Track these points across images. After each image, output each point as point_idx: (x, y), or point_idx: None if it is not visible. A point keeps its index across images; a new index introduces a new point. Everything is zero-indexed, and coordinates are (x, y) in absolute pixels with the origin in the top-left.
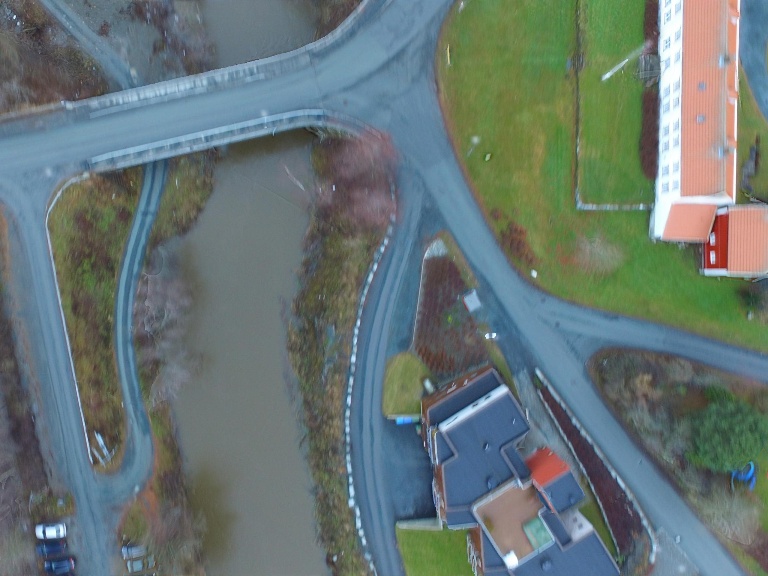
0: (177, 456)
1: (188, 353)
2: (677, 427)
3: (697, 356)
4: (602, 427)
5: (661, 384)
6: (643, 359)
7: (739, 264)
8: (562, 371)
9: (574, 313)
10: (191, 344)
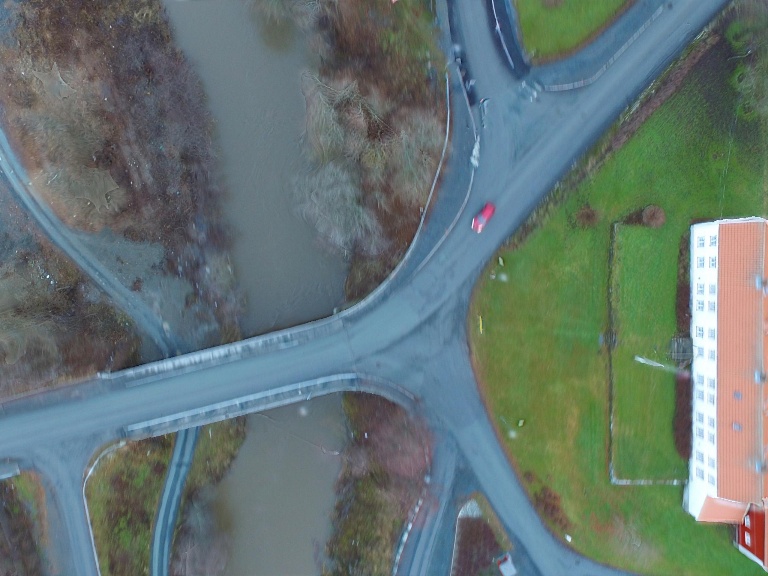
0: None
1: None
2: None
3: None
4: None
5: None
6: None
7: None
8: None
9: None
10: None
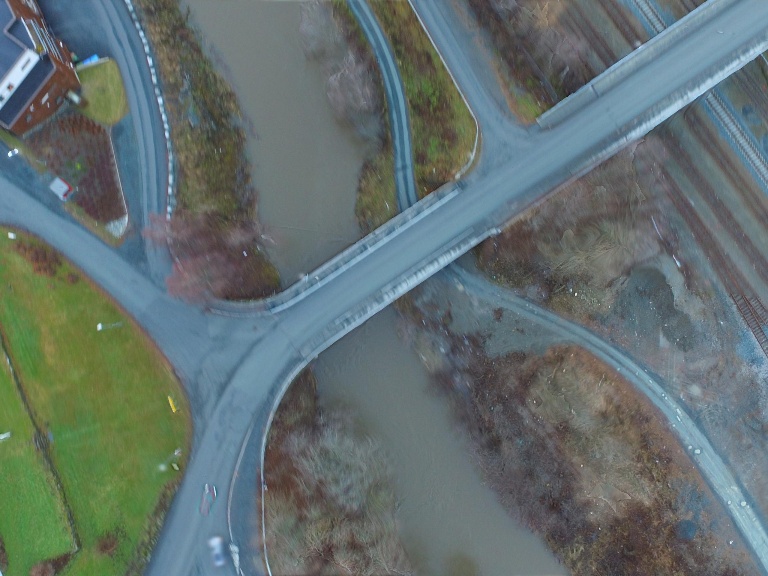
0: None
1: None
2: None
3: None
4: None
5: None
6: None
7: None
8: None
9: None
10: None
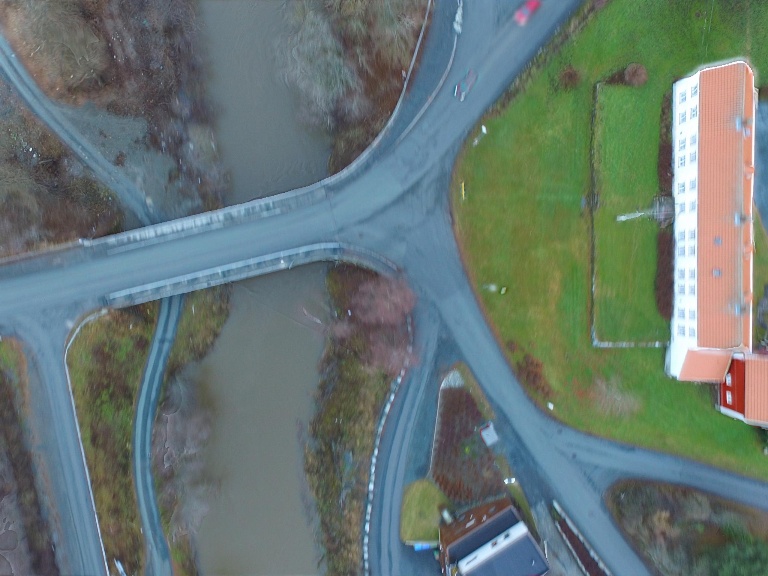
0: None
1: (207, 483)
2: (696, 568)
3: (714, 489)
4: (620, 558)
5: (679, 521)
6: (660, 494)
7: (756, 414)
8: (579, 503)
9: (591, 444)
10: (210, 473)
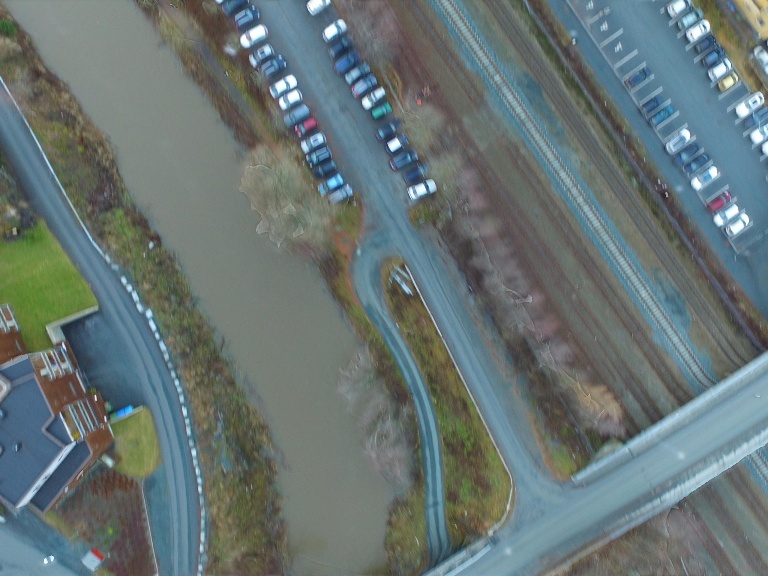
0: (334, 292)
1: None
2: None
3: None
4: None
5: None
6: None
7: None
8: None
9: None
10: None
